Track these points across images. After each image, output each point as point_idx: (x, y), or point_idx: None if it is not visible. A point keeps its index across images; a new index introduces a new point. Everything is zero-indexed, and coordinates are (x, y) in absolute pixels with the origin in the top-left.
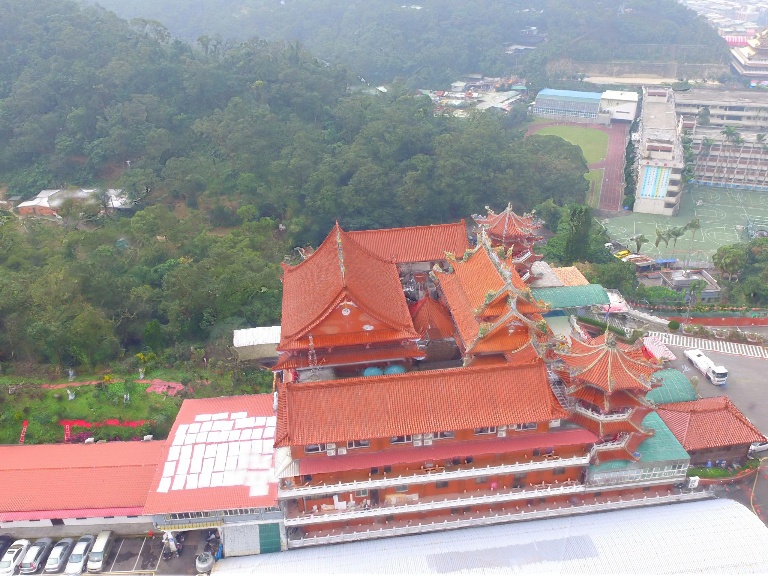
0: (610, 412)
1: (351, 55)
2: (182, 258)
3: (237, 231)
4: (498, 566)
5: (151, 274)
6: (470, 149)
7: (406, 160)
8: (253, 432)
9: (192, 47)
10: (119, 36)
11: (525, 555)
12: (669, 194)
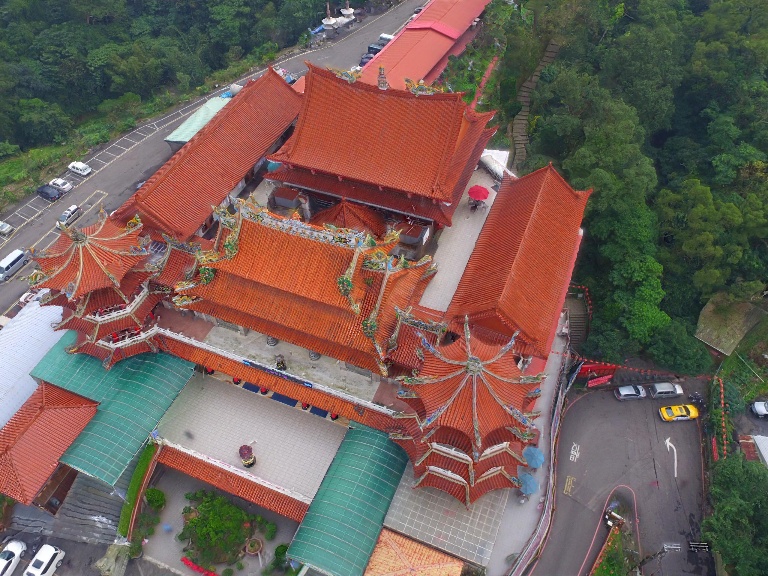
0: None
1: None
2: (762, 163)
3: None
4: None
5: (725, 139)
6: None
7: None
8: None
9: None
10: None
11: None
12: None
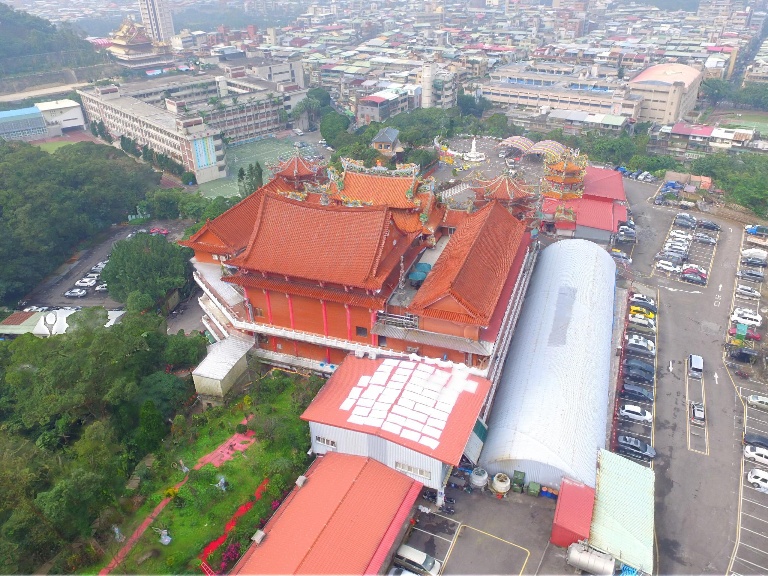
0: (520, 217)
1: None
2: None
3: None
4: (570, 322)
5: None
6: (33, 173)
7: None
8: (400, 374)
9: None
10: None
11: (566, 310)
12: (218, 159)
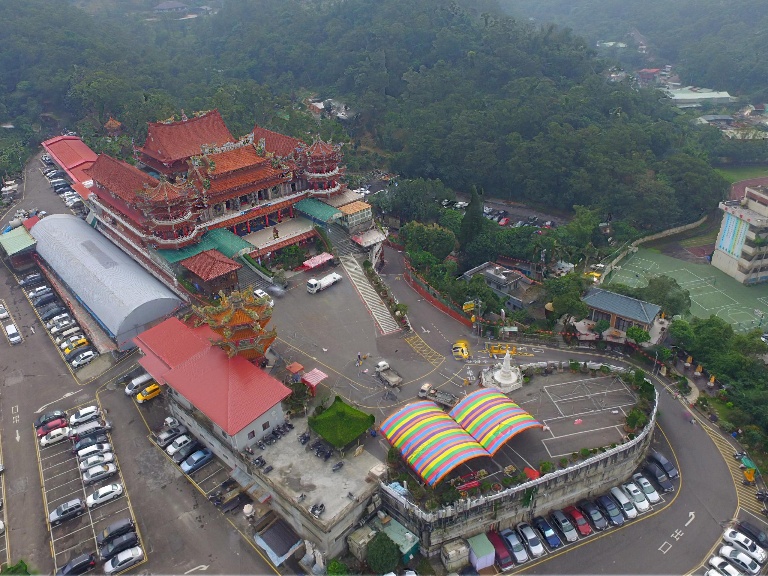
0: None
1: (725, 55)
2: None
3: (323, 137)
4: (90, 252)
5: None
6: (578, 144)
7: (506, 135)
8: None
9: (473, 20)
10: (436, 7)
11: (99, 255)
12: (745, 255)
